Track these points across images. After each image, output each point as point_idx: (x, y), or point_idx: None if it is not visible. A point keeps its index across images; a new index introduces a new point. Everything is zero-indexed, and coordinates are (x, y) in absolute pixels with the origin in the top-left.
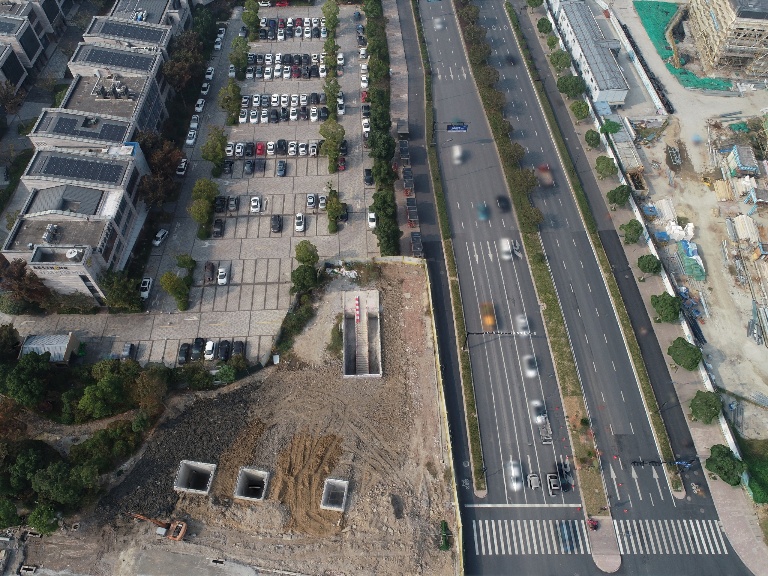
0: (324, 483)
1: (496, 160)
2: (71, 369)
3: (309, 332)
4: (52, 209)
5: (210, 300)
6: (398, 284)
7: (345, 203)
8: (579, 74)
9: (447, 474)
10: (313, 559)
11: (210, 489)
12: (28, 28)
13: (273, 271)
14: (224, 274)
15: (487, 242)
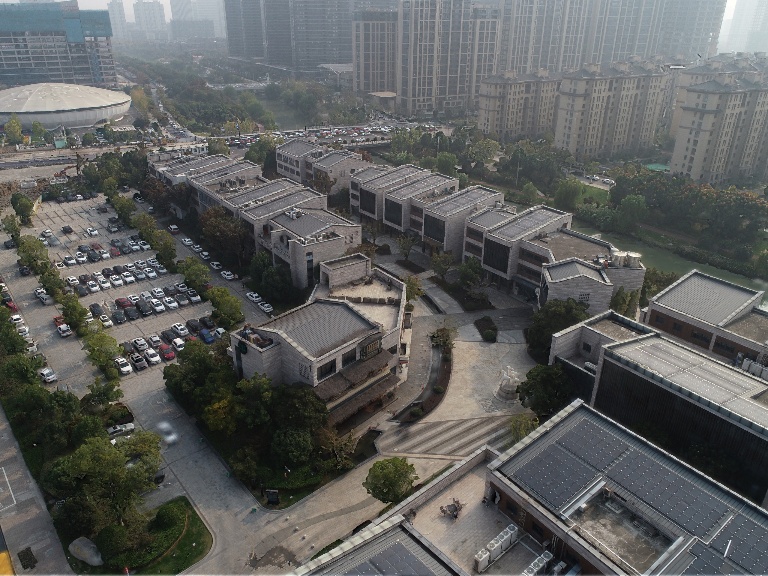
0: None
1: None
2: None
3: None
4: None
5: None
6: None
7: (8, 245)
8: None
9: None
10: None
11: None
12: None
13: None
14: (90, 208)
15: None
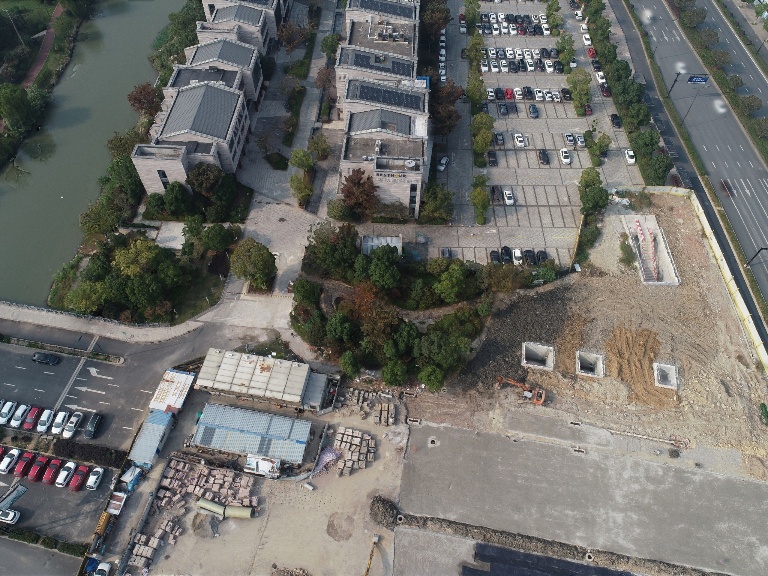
0: (652, 367)
1: (729, 111)
2: (407, 265)
3: (600, 247)
4: (375, 128)
5: (503, 217)
6: (669, 211)
7: None
8: None
9: (759, 365)
10: (660, 425)
11: (553, 366)
12: None
13: (552, 196)
14: (512, 196)
15: (741, 180)
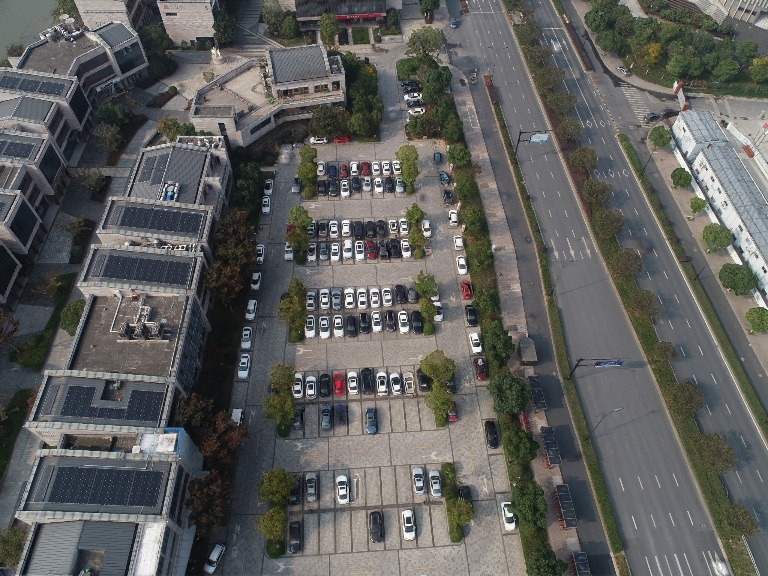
0: None
1: (657, 399)
2: None
3: None
4: (63, 573)
5: None
6: None
7: (467, 486)
8: (739, 253)
9: None
10: None
11: None
12: (21, 204)
13: None
14: None
15: (675, 556)
